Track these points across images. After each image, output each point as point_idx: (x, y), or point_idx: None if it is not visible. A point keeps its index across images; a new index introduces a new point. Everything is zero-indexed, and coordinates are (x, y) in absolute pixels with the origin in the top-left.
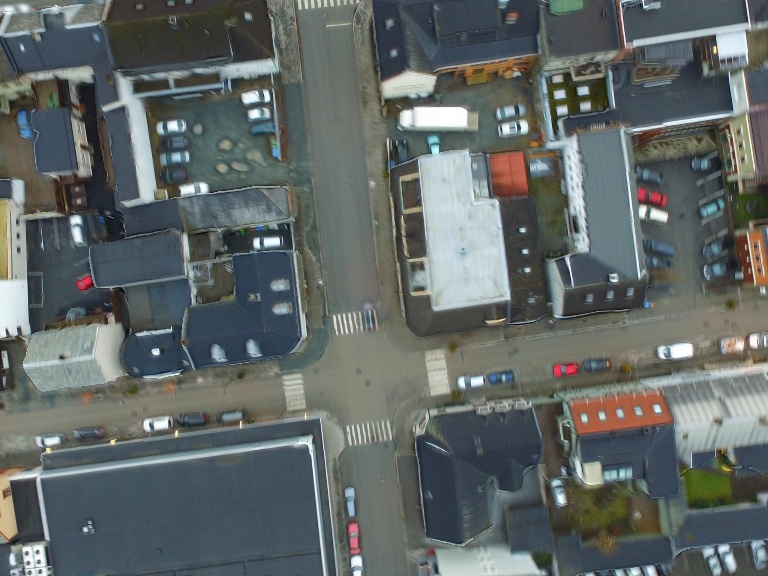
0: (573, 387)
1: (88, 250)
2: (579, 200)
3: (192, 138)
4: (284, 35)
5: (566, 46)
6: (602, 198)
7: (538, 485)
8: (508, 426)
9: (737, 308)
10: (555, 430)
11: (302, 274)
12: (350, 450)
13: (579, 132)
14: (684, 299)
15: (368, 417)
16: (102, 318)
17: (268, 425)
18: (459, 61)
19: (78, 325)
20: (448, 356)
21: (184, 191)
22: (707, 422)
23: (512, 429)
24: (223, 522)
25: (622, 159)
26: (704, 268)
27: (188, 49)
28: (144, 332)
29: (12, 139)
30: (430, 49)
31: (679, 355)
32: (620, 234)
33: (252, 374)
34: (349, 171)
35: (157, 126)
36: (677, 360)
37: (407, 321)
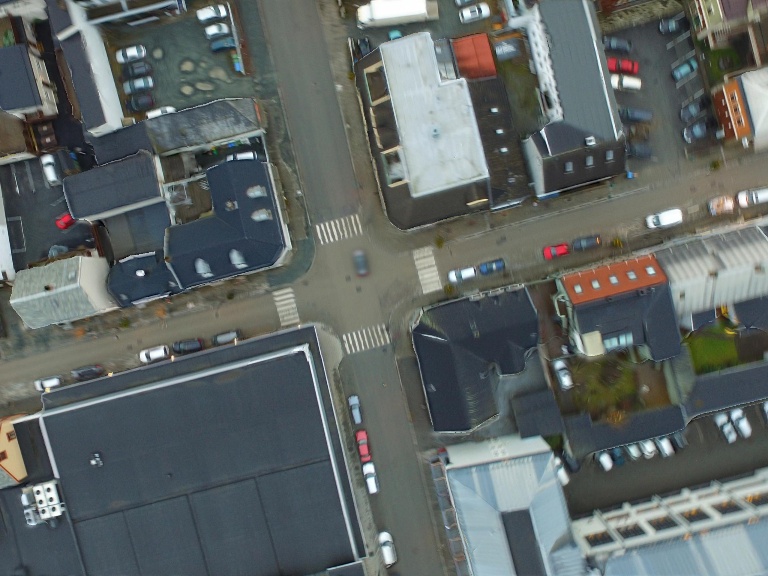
0: (565, 268)
1: None
2: (548, 72)
3: (153, 63)
4: None
5: None
6: (570, 64)
7: (541, 371)
8: (502, 308)
9: (722, 168)
10: (551, 310)
11: (279, 184)
12: (349, 358)
13: (539, 0)
14: (667, 166)
15: (363, 323)
16: (84, 251)
17: (263, 339)
18: None
19: None
20: (436, 252)
21: (151, 116)
22: (702, 277)
23: (507, 310)
24: (229, 440)
25: (587, 26)
26: (684, 131)
27: None
28: (127, 257)
29: None
30: None
31: (668, 222)
32: (592, 98)
33: (242, 294)
34: (314, 78)
35: (117, 55)
36: (667, 227)
37: (389, 215)
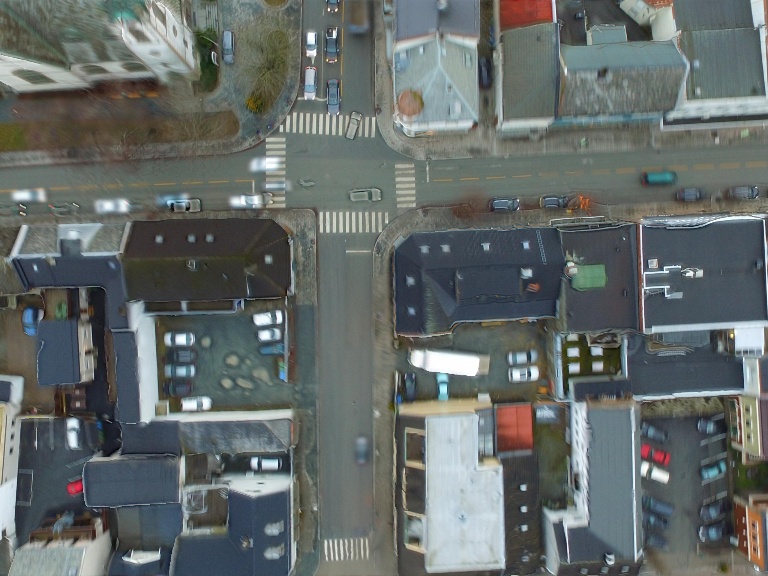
0: None
1: (82, 453)
2: (583, 464)
3: (199, 350)
4: (302, 257)
5: (585, 321)
6: (606, 473)
7: None
8: None
9: (729, 571)
10: None
11: (297, 503)
12: None
13: (589, 403)
14: (677, 557)
15: None
16: (90, 533)
17: None
18: (476, 316)
19: (65, 540)
20: None
21: (186, 406)
22: None
23: None
24: None
25: (629, 424)
26: (700, 530)
27: (204, 289)
28: (131, 559)
29: (16, 333)
30: (448, 305)
31: None
32: (620, 511)
33: None
34: (355, 397)
35: (165, 336)
36: None
37: (399, 570)
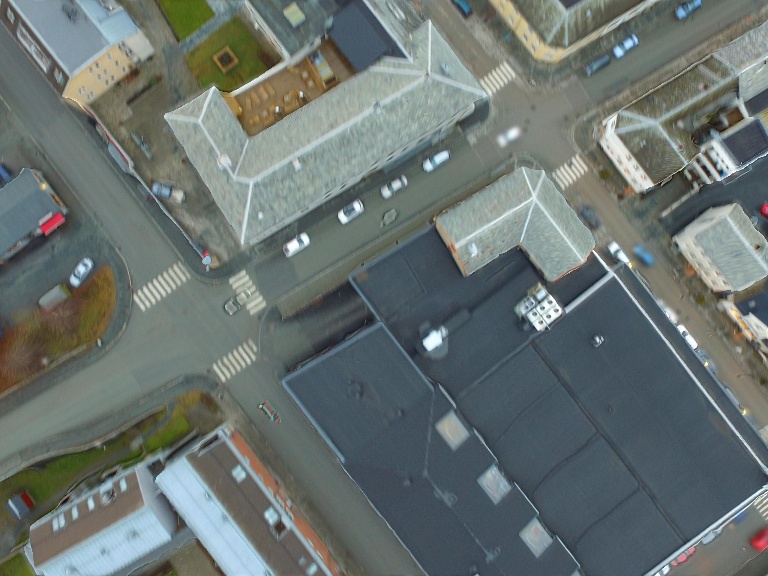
0: None
1: None
2: None
3: None
4: None
5: None
6: None
7: None
8: None
9: None
10: None
11: None
12: None
13: None
14: None
15: None
16: None
17: (759, 435)
18: None
19: None
20: None
21: None
22: None
23: None
24: (664, 447)
25: None
26: None
27: None
28: None
29: None
30: None
31: None
32: None
33: (766, 389)
34: None
35: None
36: None
37: None
